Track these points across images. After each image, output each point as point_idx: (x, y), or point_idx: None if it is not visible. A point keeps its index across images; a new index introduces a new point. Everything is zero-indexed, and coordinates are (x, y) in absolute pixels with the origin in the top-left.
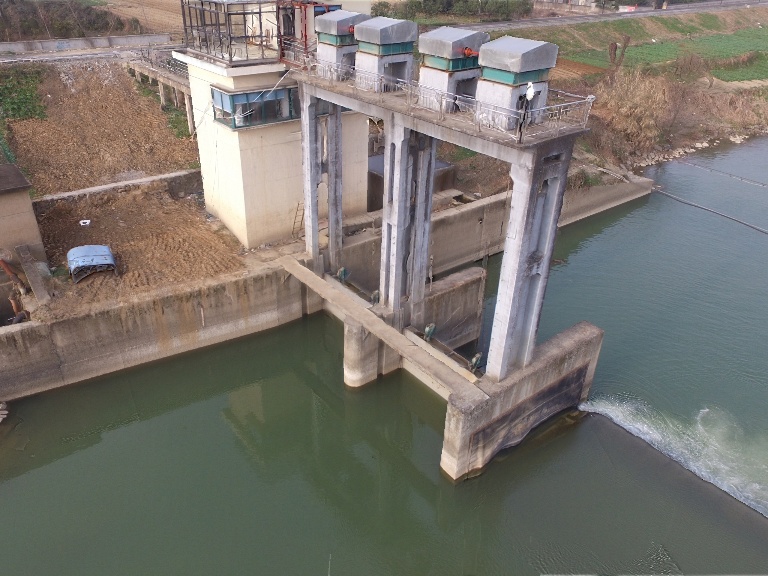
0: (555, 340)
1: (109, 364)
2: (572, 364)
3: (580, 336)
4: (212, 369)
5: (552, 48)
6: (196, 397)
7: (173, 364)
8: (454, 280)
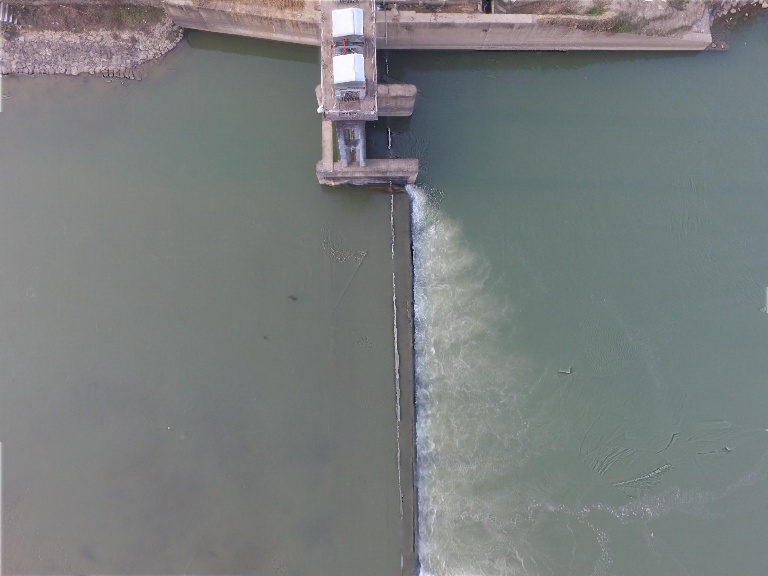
0: (391, 161)
1: (228, 30)
2: (394, 174)
3: (404, 166)
4: (282, 50)
5: (360, 82)
6: (275, 57)
7: (261, 41)
8: (392, 90)
